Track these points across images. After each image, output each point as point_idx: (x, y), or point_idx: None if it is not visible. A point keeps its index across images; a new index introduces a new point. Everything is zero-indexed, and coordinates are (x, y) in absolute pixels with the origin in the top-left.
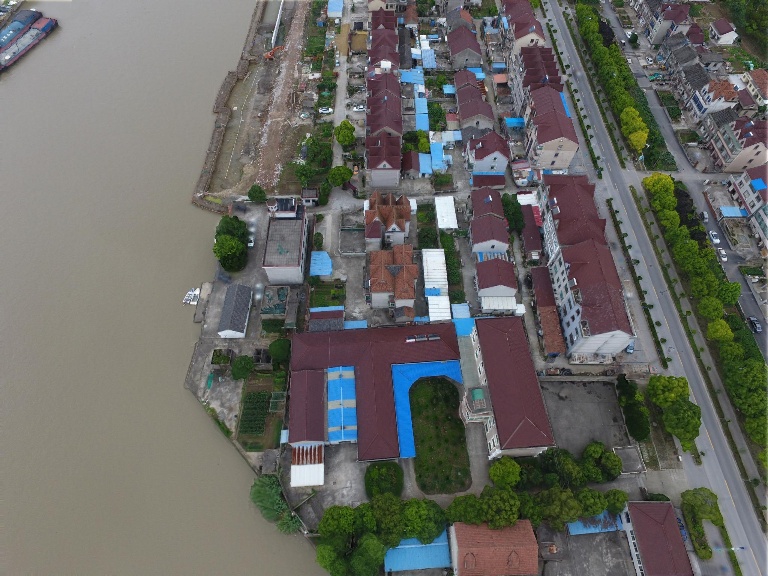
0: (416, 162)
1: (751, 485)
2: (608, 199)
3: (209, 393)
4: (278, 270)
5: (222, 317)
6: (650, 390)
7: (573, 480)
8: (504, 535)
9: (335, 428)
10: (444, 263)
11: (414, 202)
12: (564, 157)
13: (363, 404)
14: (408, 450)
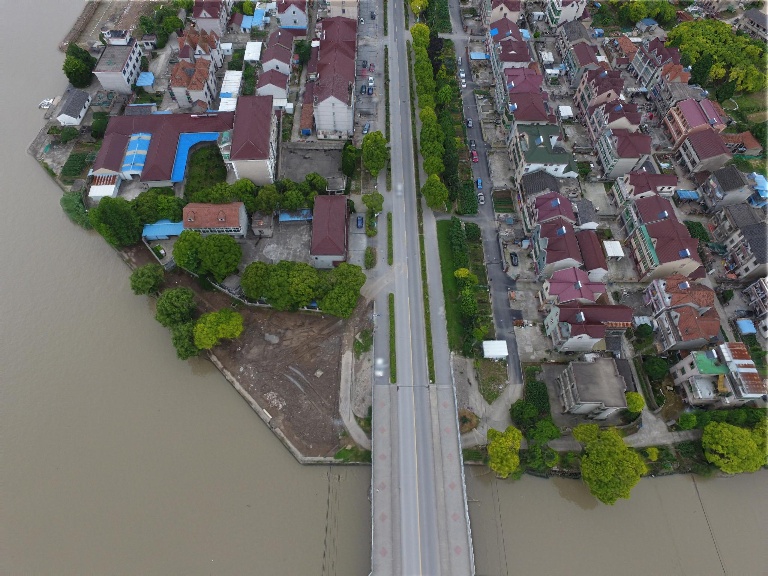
0: (239, 20)
1: (419, 199)
2: (386, 47)
3: (45, 155)
4: (107, 77)
5: (62, 109)
6: (362, 145)
7: (288, 190)
8: (219, 205)
9: (127, 164)
10: (240, 79)
11: (230, 45)
12: (350, 14)
13: (151, 151)
14: (178, 178)
